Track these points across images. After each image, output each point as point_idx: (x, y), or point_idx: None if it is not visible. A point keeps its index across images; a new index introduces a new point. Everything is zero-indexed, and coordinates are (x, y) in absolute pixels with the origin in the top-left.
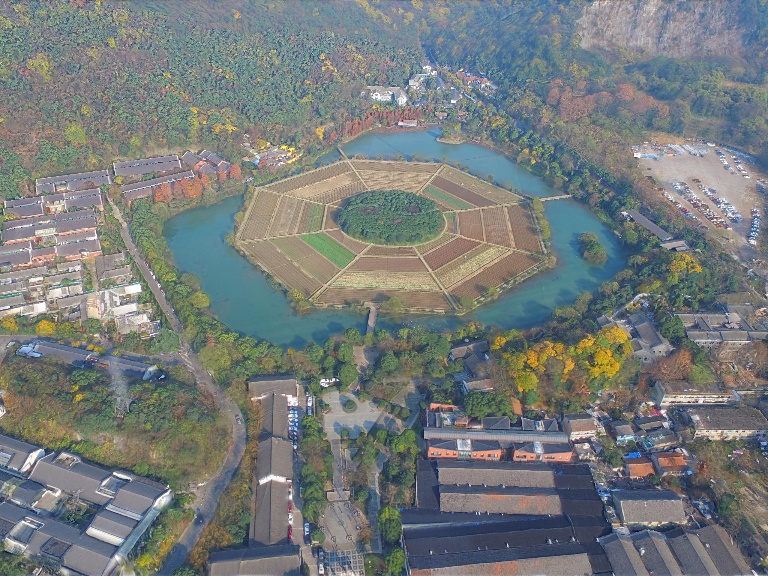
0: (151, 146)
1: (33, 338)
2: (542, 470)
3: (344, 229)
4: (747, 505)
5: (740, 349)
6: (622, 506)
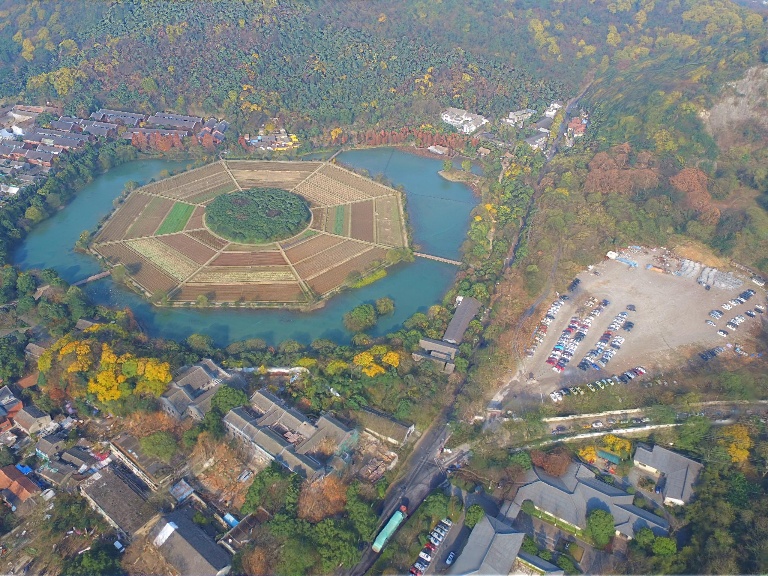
0: (192, 107)
1: None
2: None
3: None
4: (4, 570)
5: None
6: None
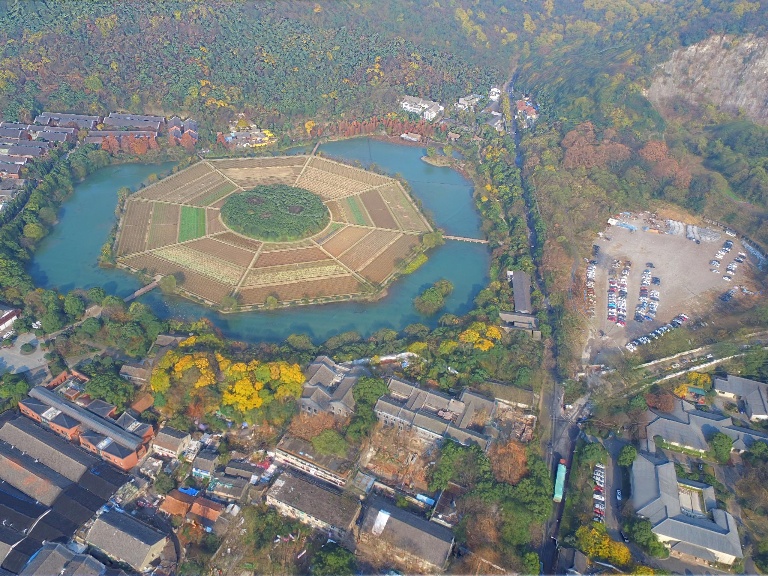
0: (149, 105)
1: None
2: (80, 462)
3: (220, 210)
4: None
5: (433, 442)
6: (93, 524)
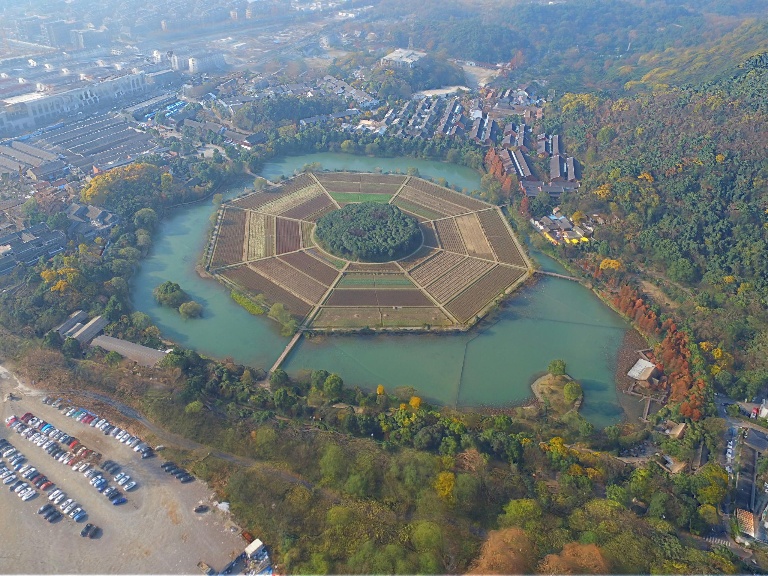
0: None
1: None
2: (104, 159)
3: None
4: None
5: None
6: None
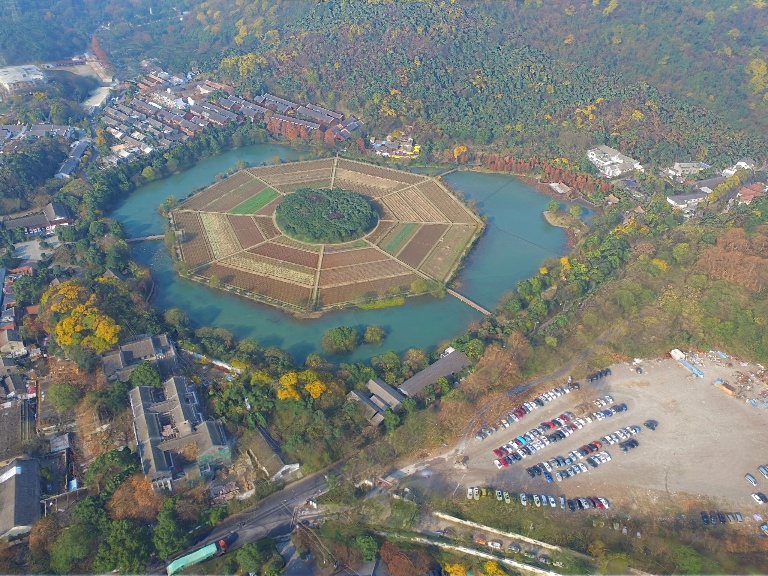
0: (340, 103)
1: None
2: None
3: None
4: None
5: None
6: None
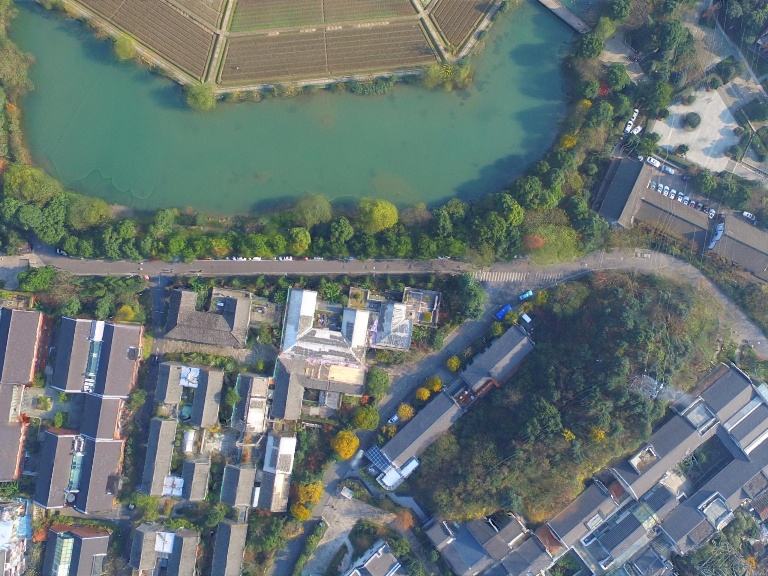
0: None
1: (337, 462)
2: None
3: None
4: None
5: None
6: None
